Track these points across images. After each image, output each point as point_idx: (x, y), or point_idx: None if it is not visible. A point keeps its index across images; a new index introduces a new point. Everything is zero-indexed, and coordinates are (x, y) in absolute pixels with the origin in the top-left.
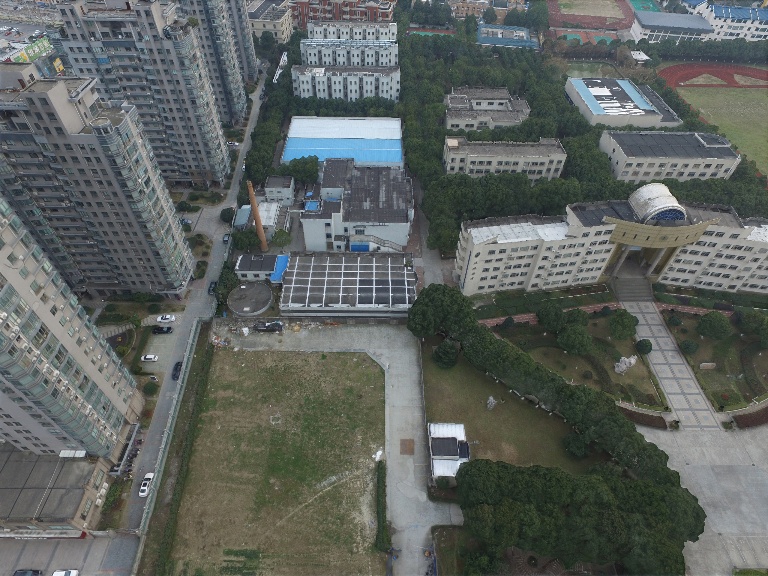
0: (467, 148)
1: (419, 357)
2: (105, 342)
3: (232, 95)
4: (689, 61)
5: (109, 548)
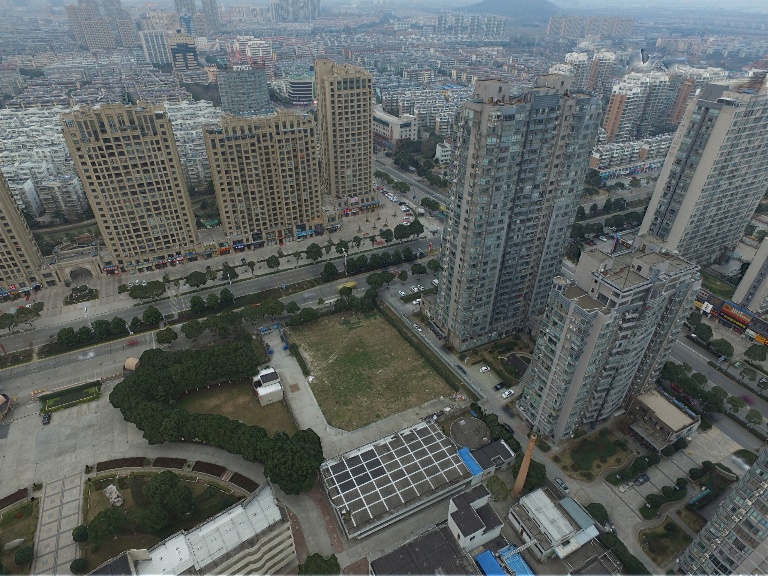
0: None
1: None
2: (465, 304)
3: None
4: None
5: (411, 312)
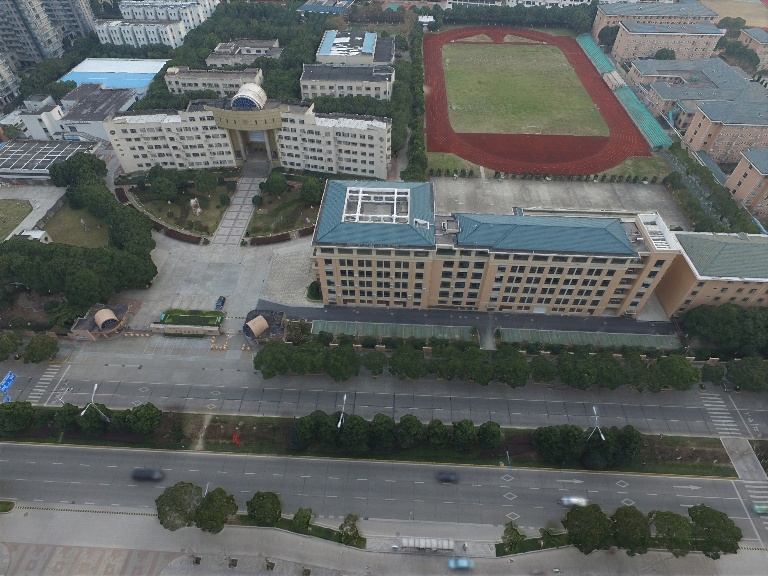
0: (183, 74)
1: (62, 202)
2: None
3: (38, 40)
4: (478, 25)
5: None
